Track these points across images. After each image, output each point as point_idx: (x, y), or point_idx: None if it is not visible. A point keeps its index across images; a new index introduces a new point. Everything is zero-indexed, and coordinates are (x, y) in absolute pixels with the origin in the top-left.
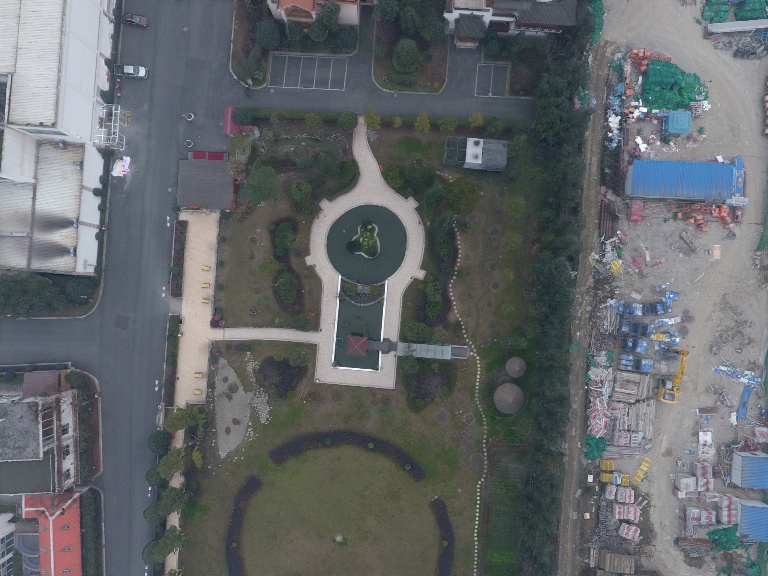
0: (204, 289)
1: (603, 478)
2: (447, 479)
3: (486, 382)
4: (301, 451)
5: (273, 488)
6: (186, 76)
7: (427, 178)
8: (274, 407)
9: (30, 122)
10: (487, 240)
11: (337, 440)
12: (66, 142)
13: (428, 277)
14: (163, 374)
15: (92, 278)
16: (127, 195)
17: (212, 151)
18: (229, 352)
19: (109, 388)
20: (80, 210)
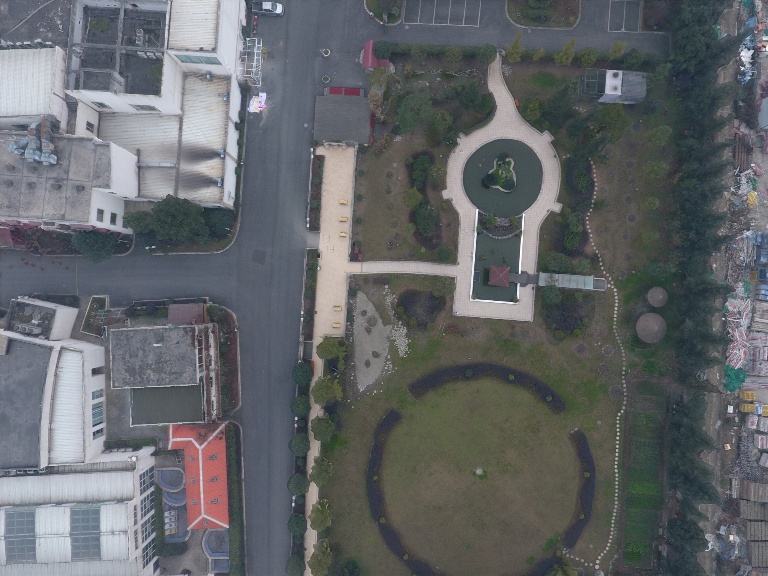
0: (341, 223)
1: (745, 408)
2: (586, 411)
3: (624, 314)
4: (441, 384)
5: (412, 421)
6: (321, 13)
7: (568, 109)
8: (412, 340)
9: (190, 47)
10: (622, 173)
11: (477, 372)
12: (212, 74)
13: (566, 209)
14: (301, 308)
15: (231, 212)
16: (263, 131)
17: (348, 87)
18: (367, 285)
19: (247, 322)
20: (227, 141)
